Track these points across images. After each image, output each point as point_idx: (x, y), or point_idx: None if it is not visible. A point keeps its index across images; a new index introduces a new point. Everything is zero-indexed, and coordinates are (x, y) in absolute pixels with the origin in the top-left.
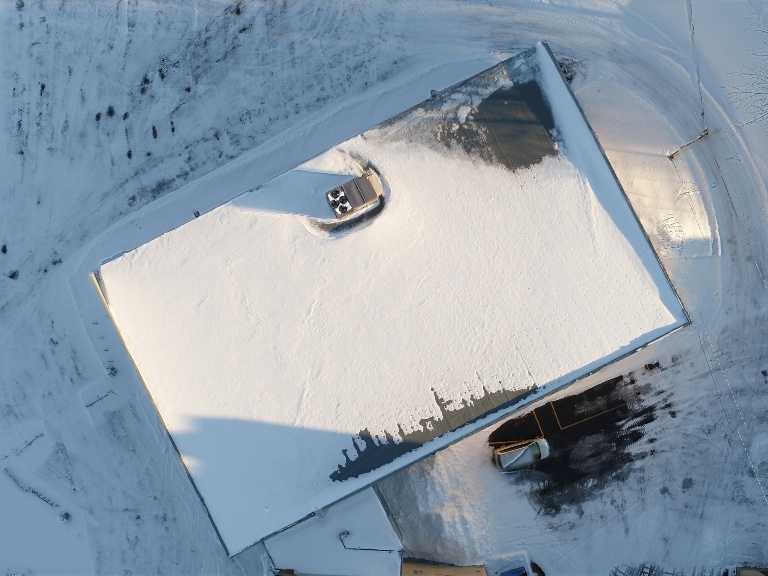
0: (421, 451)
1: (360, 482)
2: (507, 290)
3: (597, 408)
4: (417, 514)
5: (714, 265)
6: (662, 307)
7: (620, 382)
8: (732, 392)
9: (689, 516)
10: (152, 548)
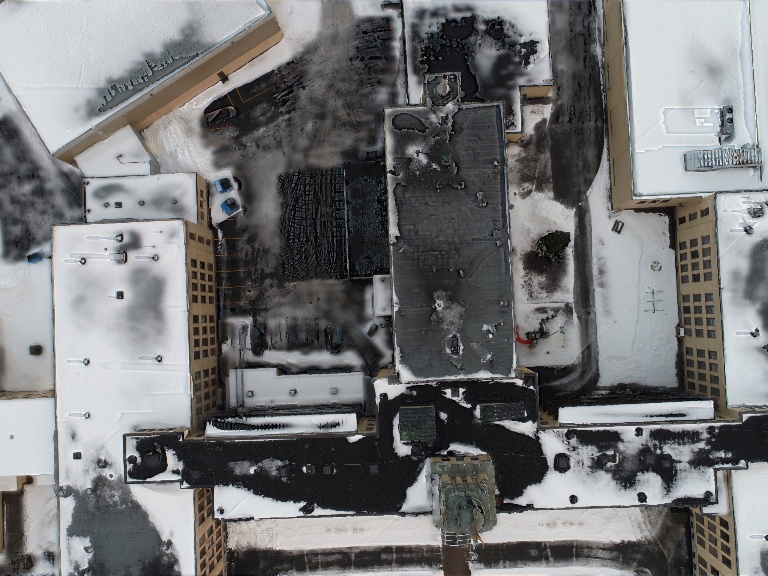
0: (143, 92)
1: (113, 111)
2: (180, 7)
3: (262, 89)
4: (166, 153)
5: (318, 4)
6: (258, 6)
7: (273, 73)
8: (334, 72)
9: (317, 142)
10: (28, 193)
